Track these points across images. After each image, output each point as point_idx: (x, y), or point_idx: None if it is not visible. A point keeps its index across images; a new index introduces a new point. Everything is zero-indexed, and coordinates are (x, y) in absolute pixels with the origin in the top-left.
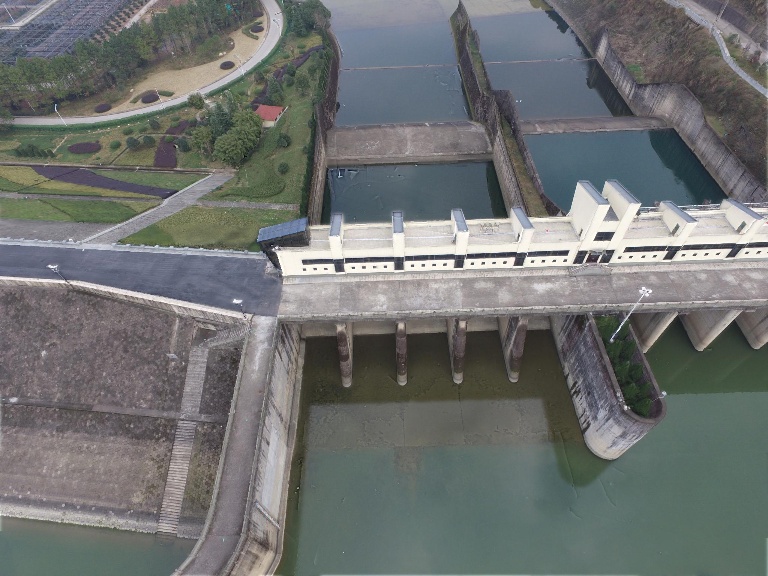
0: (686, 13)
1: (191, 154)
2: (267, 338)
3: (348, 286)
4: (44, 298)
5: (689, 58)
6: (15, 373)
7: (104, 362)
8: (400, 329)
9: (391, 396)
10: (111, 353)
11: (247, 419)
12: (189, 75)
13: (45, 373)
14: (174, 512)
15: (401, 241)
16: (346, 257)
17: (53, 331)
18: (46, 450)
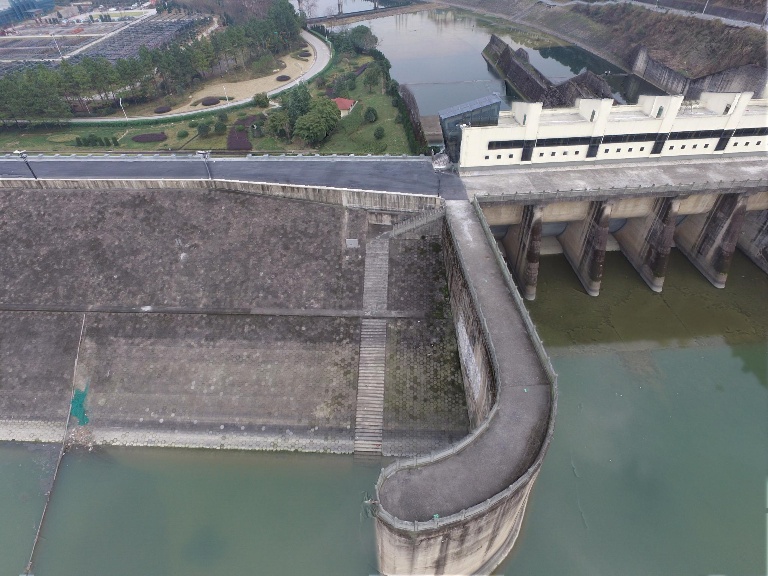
0: (723, 22)
1: (265, 139)
2: (468, 216)
3: (536, 176)
4: (180, 199)
5: (747, 47)
6: (147, 279)
7: (260, 261)
8: (606, 215)
9: (587, 306)
10: (268, 251)
11: (486, 280)
12: (246, 85)
13: (186, 277)
14: (373, 426)
15: (607, 111)
16: (539, 137)
17: (194, 232)
18: (193, 362)
